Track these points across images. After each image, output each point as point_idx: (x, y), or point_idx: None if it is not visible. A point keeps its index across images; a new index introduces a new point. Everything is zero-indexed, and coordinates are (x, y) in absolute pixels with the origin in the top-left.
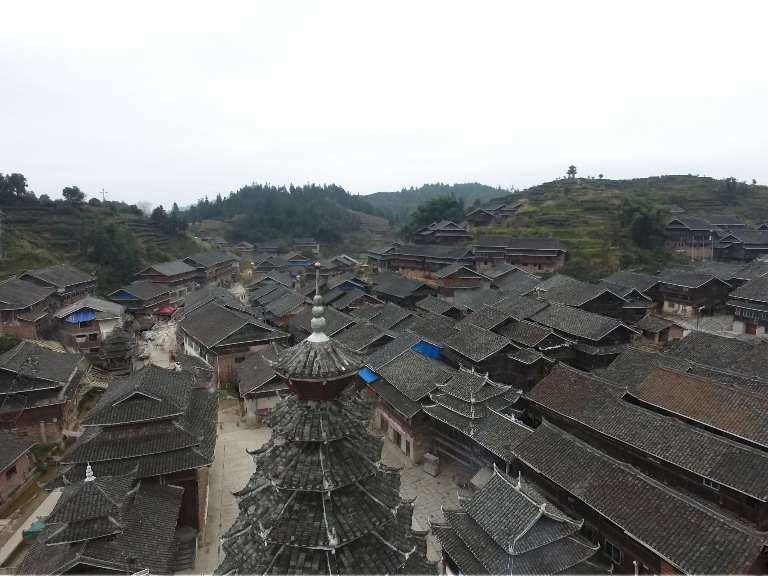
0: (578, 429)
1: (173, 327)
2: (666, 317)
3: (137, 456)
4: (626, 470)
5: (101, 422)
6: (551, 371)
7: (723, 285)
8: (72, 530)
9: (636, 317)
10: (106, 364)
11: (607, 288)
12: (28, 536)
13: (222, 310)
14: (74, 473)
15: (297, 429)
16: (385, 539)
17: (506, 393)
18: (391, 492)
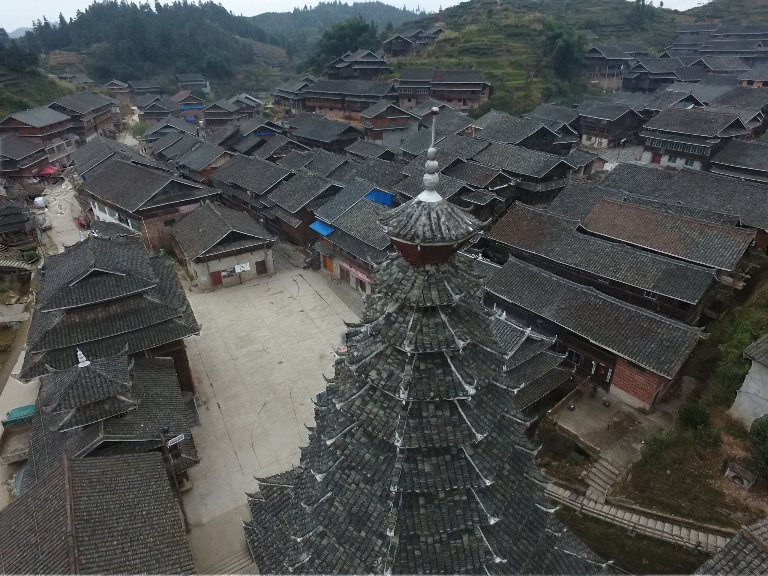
0: (536, 261)
1: (73, 191)
2: (592, 151)
3: (116, 334)
4: (588, 292)
5: (63, 305)
6: (508, 210)
7: (636, 116)
8: (82, 414)
9: (563, 152)
10: (1, 239)
11: (543, 124)
12: (9, 425)
13: (132, 167)
14: (49, 360)
15: (425, 295)
16: (495, 381)
17: None
18: (490, 340)
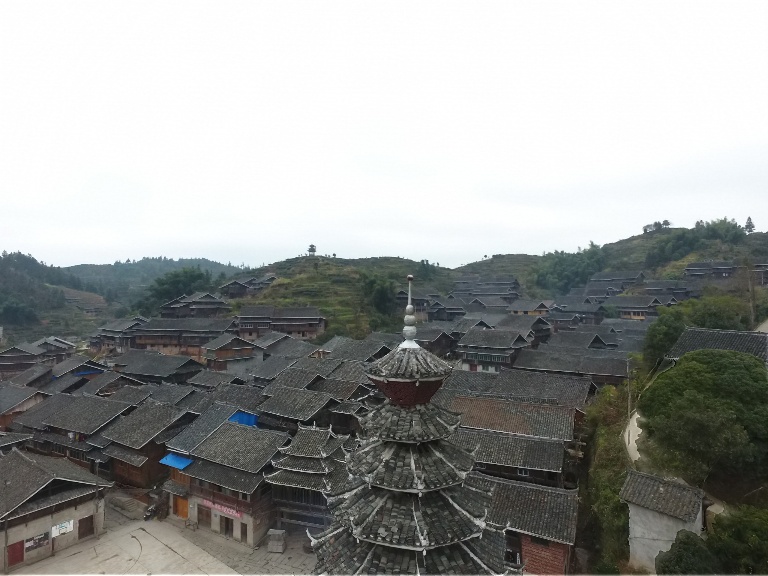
0: None
1: None
2: None
3: None
4: (475, 477)
5: None
6: None
7: (448, 338)
8: None
9: None
10: None
11: (384, 344)
12: None
13: None
14: None
15: (425, 430)
16: None
17: (345, 443)
18: None
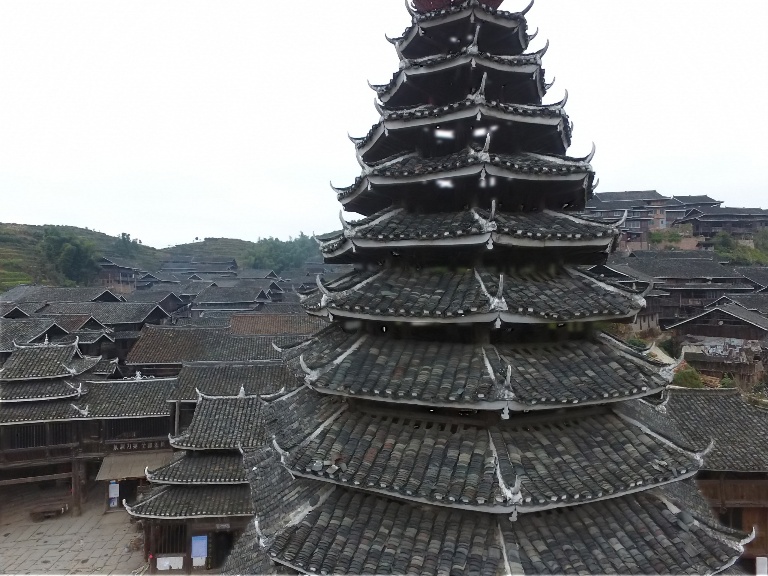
0: None
1: None
2: None
3: None
4: None
5: None
6: (140, 335)
7: (176, 301)
8: None
9: None
10: None
11: None
12: None
13: None
14: None
15: None
16: None
17: (95, 367)
18: None
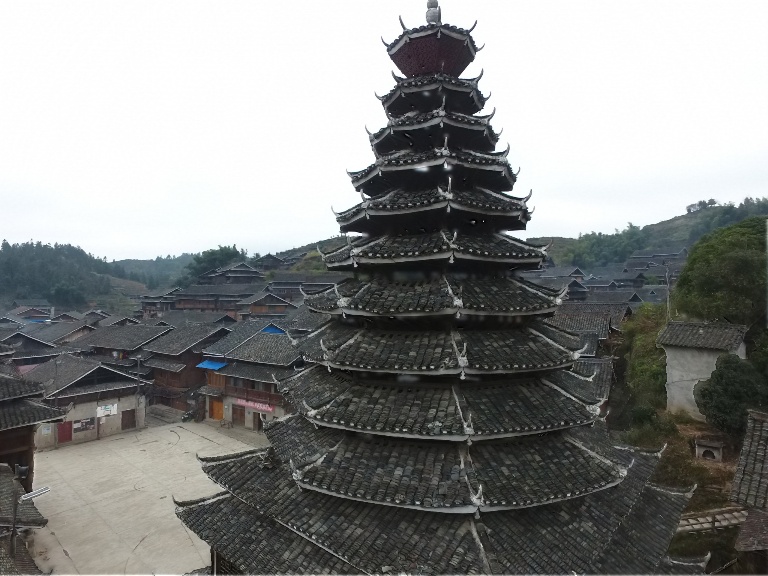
0: None
1: None
2: None
3: None
4: None
5: None
6: None
7: None
8: None
9: None
10: None
11: None
12: None
13: None
14: None
15: None
16: None
17: None
18: None
